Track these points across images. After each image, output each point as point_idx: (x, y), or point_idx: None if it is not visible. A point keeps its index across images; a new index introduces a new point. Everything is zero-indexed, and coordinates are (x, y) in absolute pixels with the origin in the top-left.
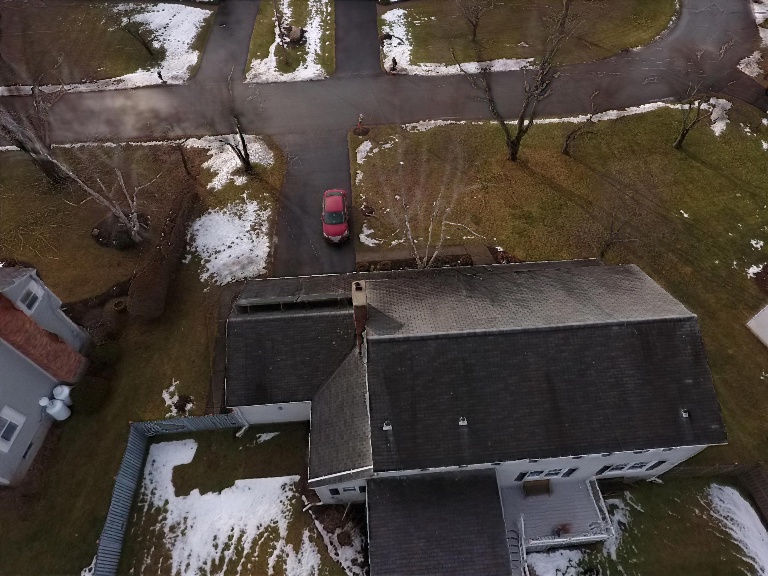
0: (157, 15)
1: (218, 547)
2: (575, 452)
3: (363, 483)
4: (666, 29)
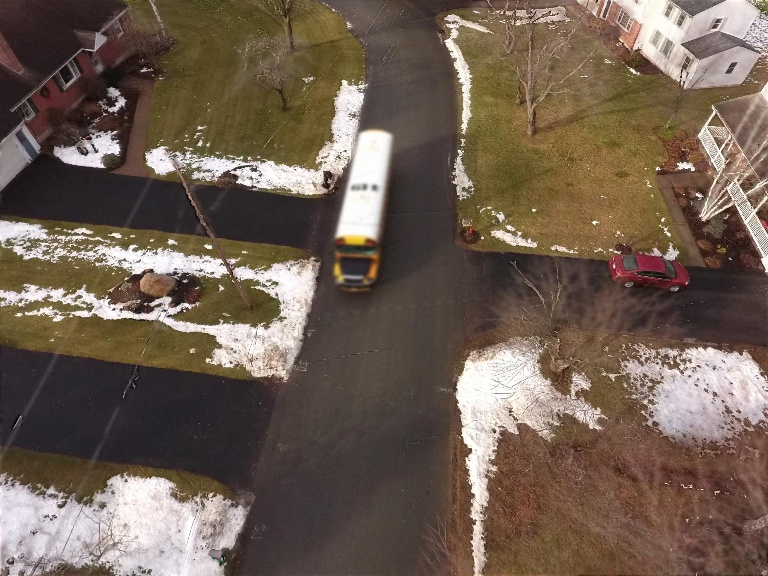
0: None
1: None
2: None
3: None
4: (321, 2)
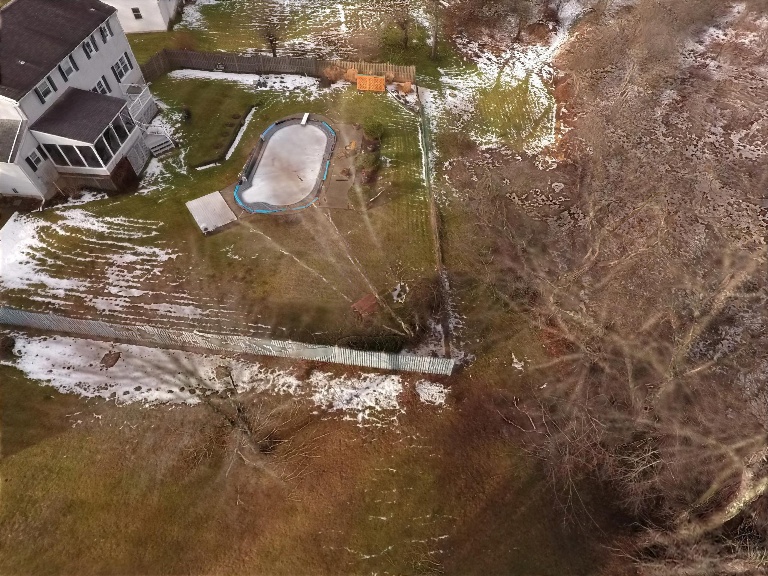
0: None
1: (29, 261)
2: (78, 43)
3: (33, 141)
4: None
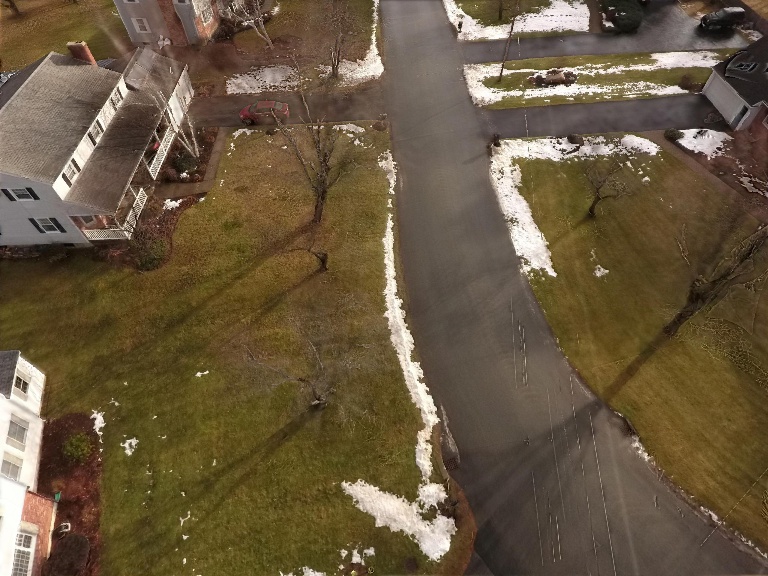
0: (565, 8)
1: None
2: None
3: None
4: None
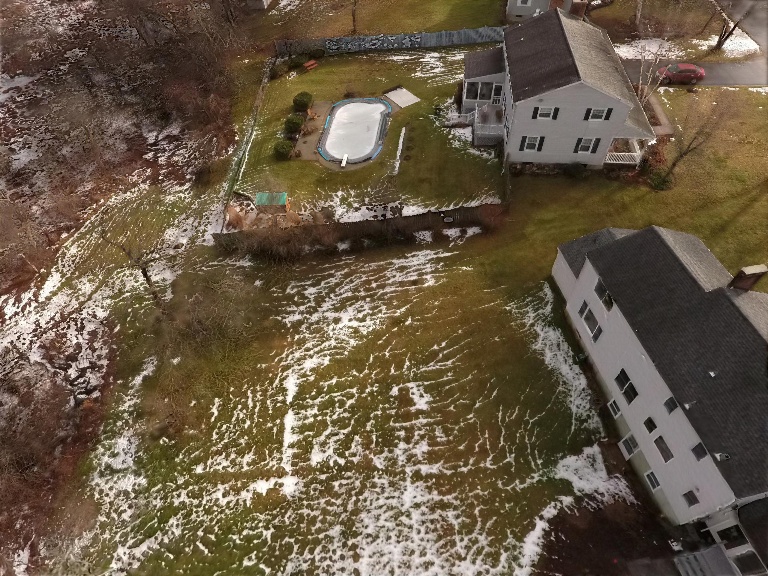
0: None
1: None
2: None
3: None
4: None
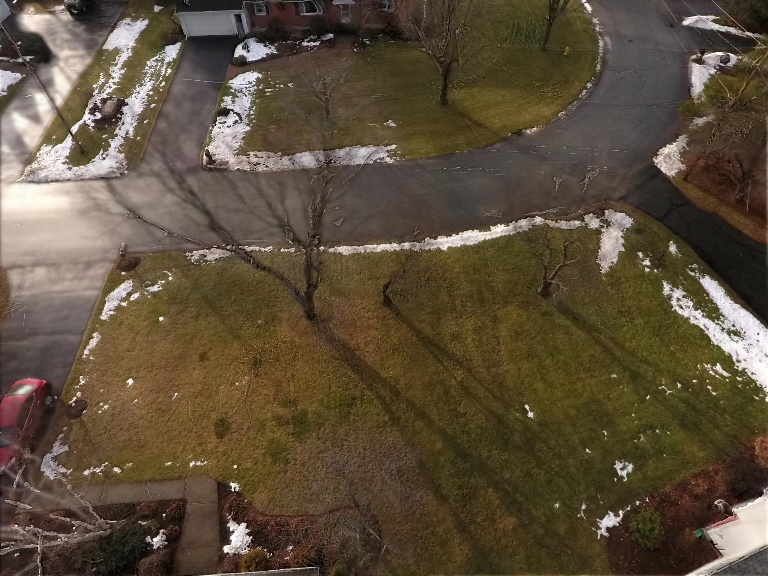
0: None
1: None
2: None
3: None
4: (575, 101)
